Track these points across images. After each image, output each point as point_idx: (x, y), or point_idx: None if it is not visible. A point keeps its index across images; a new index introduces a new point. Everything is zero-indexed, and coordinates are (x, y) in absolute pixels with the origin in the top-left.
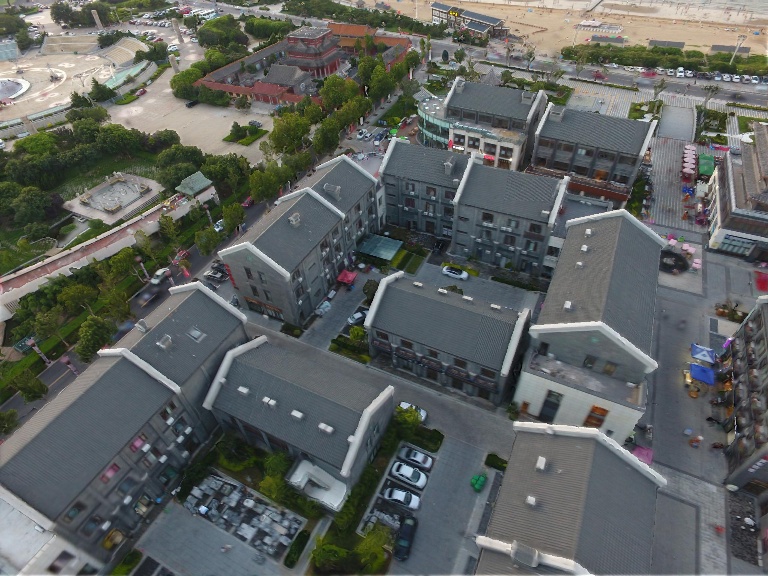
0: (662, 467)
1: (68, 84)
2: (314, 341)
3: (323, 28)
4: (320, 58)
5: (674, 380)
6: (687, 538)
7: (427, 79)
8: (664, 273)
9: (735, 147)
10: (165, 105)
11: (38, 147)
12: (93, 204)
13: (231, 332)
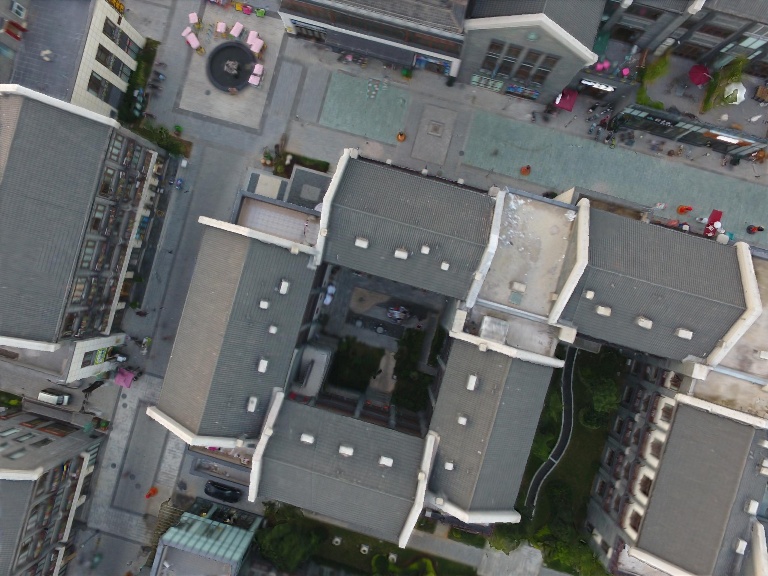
0: (153, 378)
1: None
2: None
3: None
4: None
5: (188, 274)
6: (158, 439)
7: None
8: (221, 93)
9: None
10: None
11: None
12: None
13: None
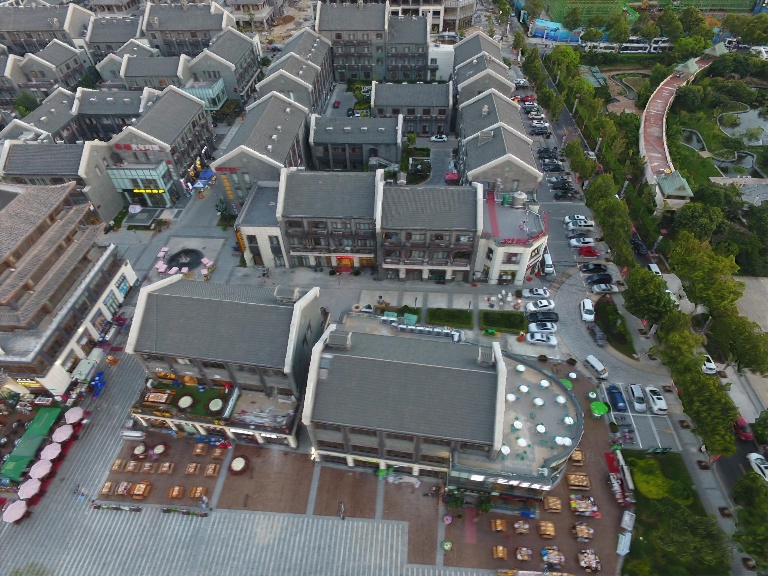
0: None
1: None
2: (442, 152)
3: None
4: None
5: None
6: None
7: None
8: None
9: None
10: None
11: None
12: (767, 186)
13: None
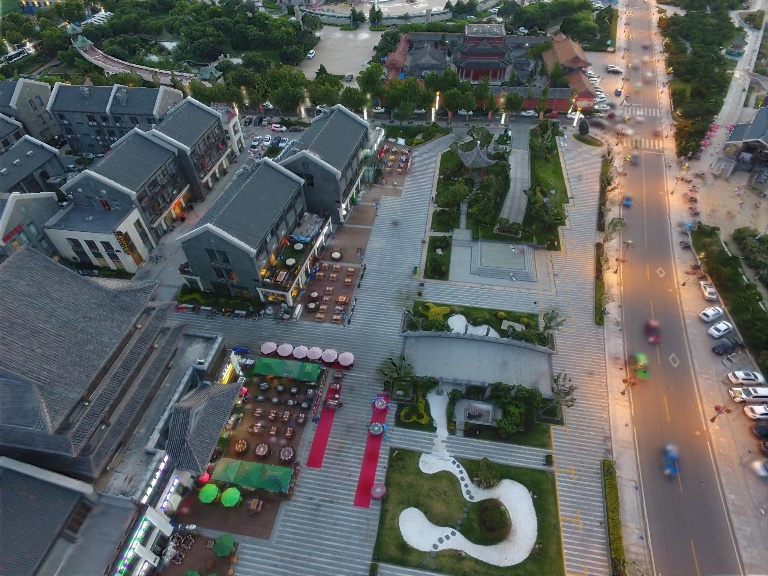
0: None
1: (405, 7)
2: None
3: (504, 32)
4: (466, 58)
5: None
6: None
7: (504, 132)
8: None
9: (376, 428)
10: (376, 42)
11: (272, 26)
12: None
13: (6, 106)
